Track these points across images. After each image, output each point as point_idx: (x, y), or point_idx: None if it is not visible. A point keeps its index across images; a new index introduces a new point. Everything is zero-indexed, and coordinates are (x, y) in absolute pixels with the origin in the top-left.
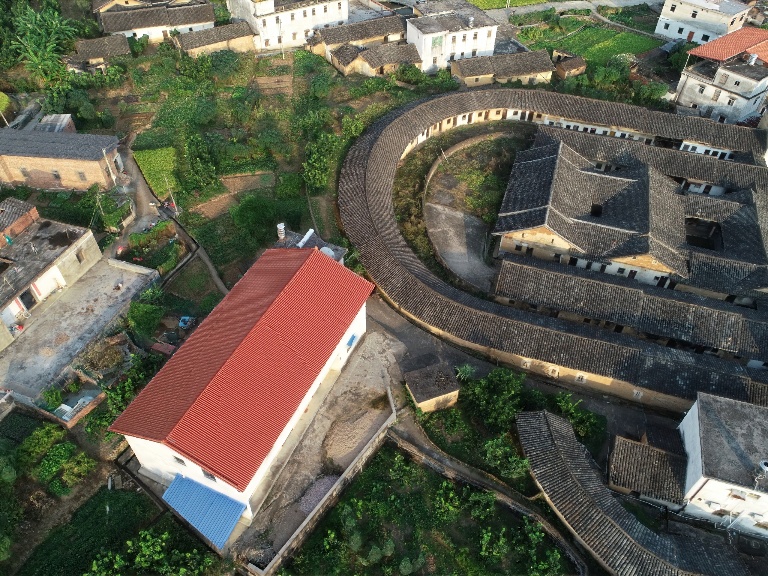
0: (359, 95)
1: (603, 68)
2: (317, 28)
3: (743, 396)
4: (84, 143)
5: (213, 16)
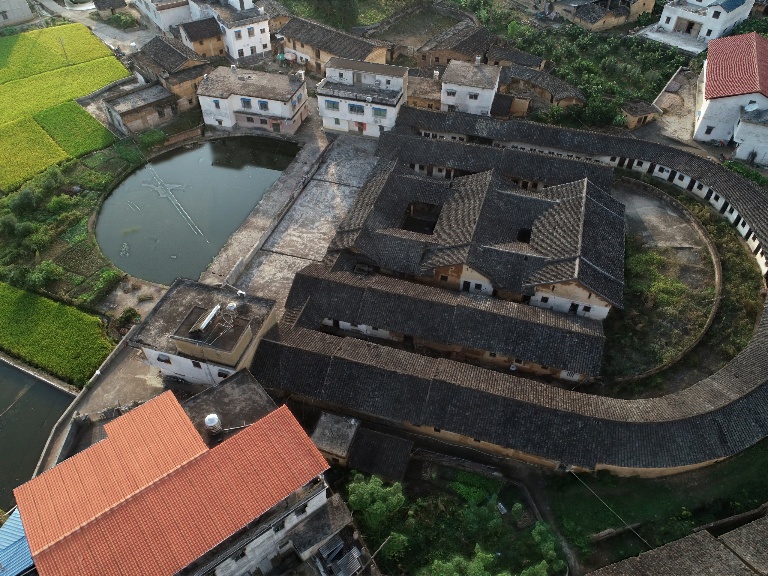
0: None
1: None
2: None
3: None
4: None
5: None
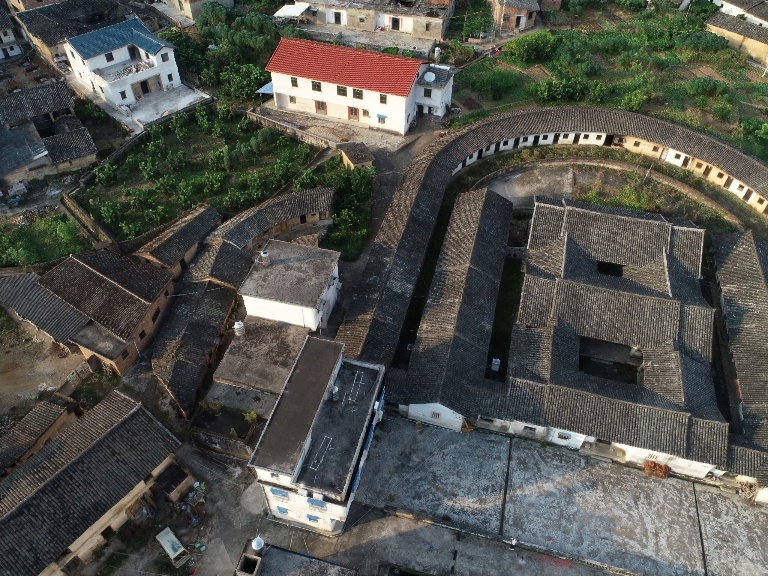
0: (701, 105)
1: None
2: None
3: (359, 313)
4: (523, 1)
5: None
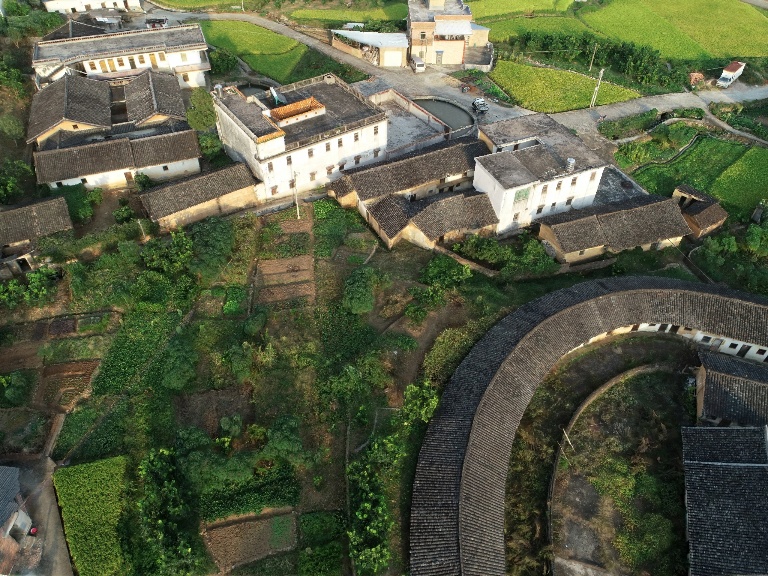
0: (421, 315)
1: (760, 229)
2: (344, 162)
3: None
4: None
5: (197, 149)
